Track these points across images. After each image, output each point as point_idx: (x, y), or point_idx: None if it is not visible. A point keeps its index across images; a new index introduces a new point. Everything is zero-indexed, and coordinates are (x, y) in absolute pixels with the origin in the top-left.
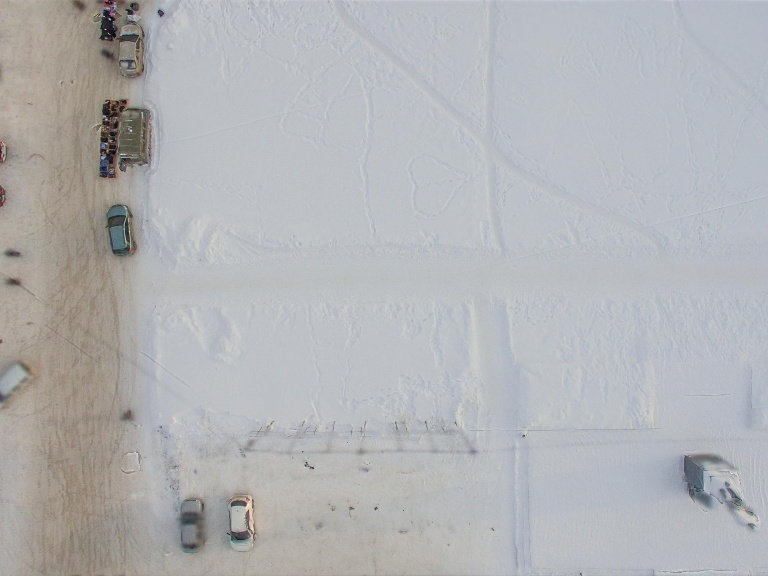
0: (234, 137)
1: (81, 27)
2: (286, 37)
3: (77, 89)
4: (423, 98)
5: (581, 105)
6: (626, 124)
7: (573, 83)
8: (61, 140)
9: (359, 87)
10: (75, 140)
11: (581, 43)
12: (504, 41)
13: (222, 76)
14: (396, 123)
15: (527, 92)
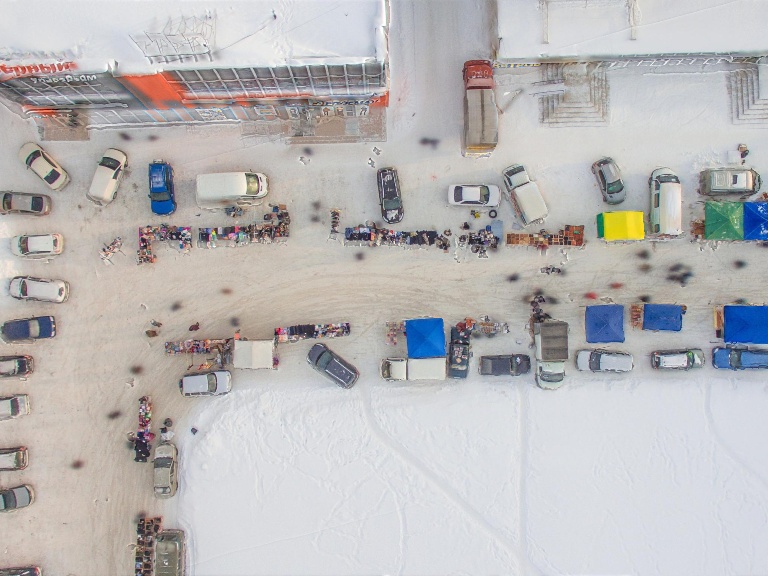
0: (268, 553)
1: (115, 444)
2: (319, 453)
3: (112, 507)
4: (456, 512)
5: (615, 515)
6: (660, 533)
7: (606, 494)
8: (96, 559)
9: (392, 503)
10: (110, 558)
11: (613, 452)
12: (536, 452)
13: (256, 495)
14: (430, 540)
15: (560, 504)
